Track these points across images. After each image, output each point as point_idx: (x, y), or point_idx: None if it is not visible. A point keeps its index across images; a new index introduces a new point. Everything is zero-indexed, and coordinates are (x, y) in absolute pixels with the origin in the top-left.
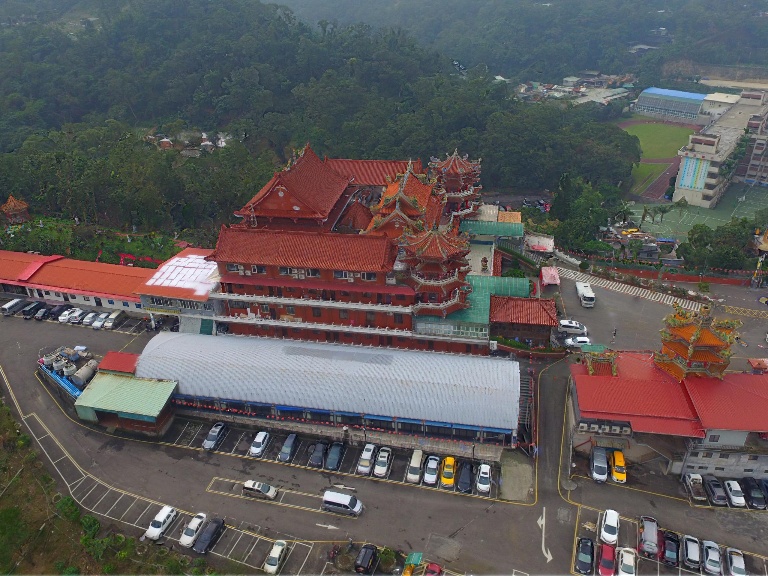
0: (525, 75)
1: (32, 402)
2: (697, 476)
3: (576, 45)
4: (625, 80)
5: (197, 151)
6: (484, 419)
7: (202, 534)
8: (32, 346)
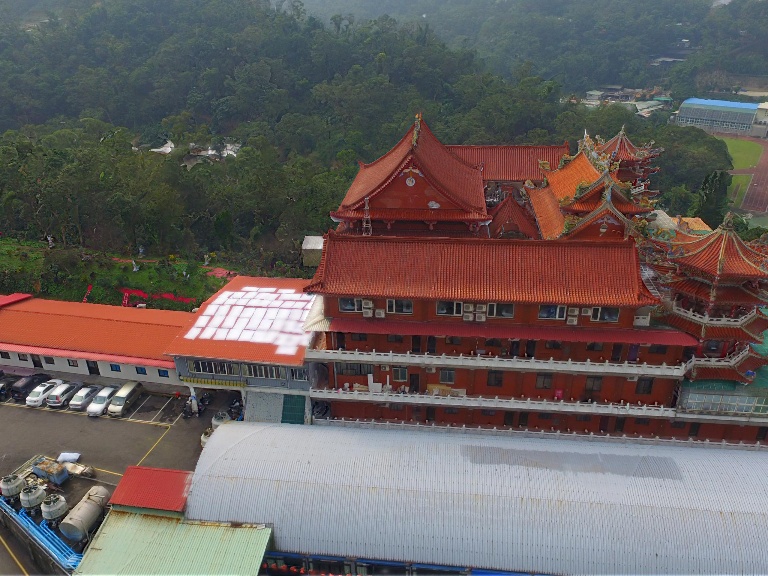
0: None
1: None
2: None
3: (595, 58)
4: (654, 93)
5: (195, 162)
6: None
7: None
8: None
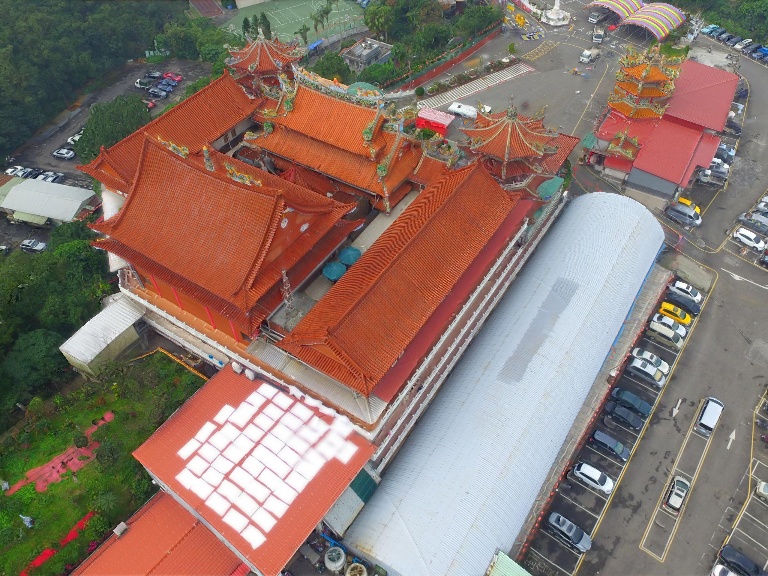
0: None
1: None
2: (709, 171)
3: None
4: None
5: None
6: (654, 252)
7: (751, 574)
8: None
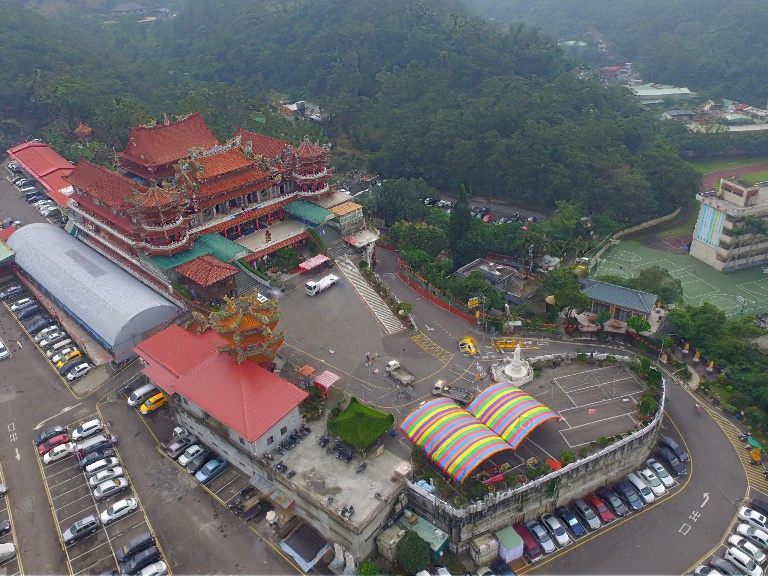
0: (716, 90)
1: None
2: (178, 430)
3: None
4: None
5: None
6: (103, 332)
7: None
8: (6, 215)
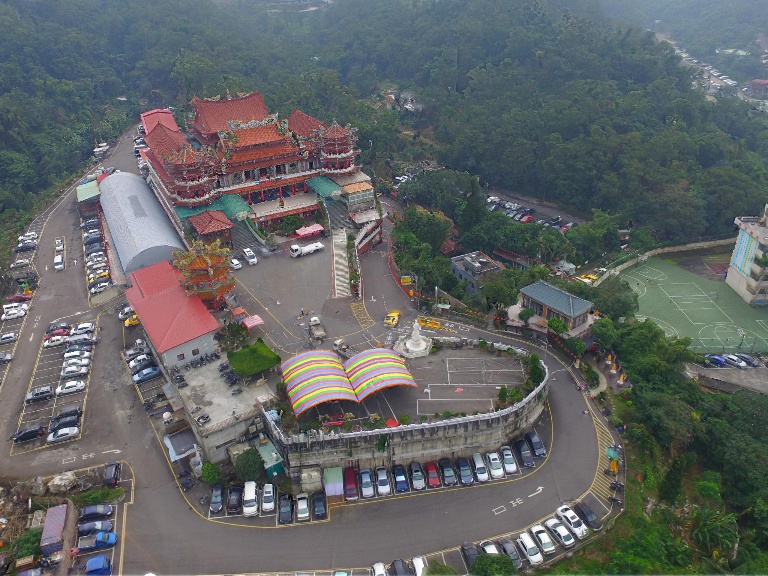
0: None
1: None
2: (139, 341)
3: None
4: None
5: None
6: None
7: None
8: None
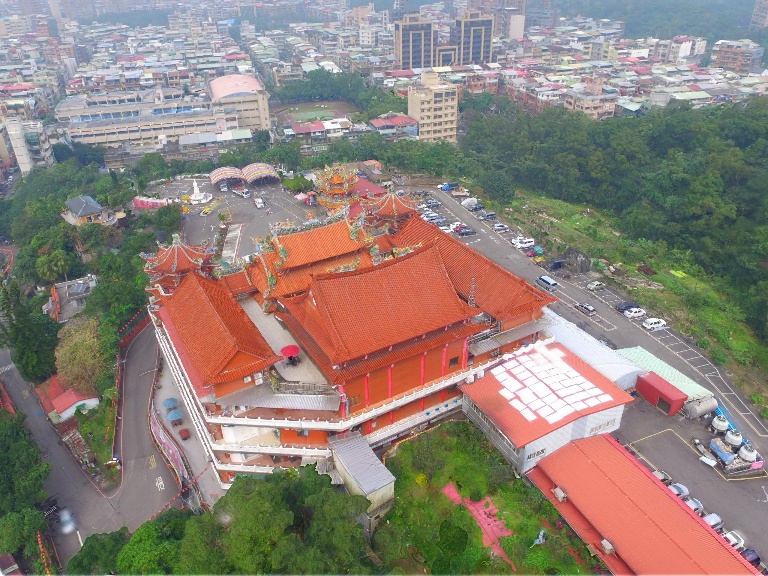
0: None
1: (766, 446)
2: None
3: None
4: None
5: None
6: None
7: None
8: None
